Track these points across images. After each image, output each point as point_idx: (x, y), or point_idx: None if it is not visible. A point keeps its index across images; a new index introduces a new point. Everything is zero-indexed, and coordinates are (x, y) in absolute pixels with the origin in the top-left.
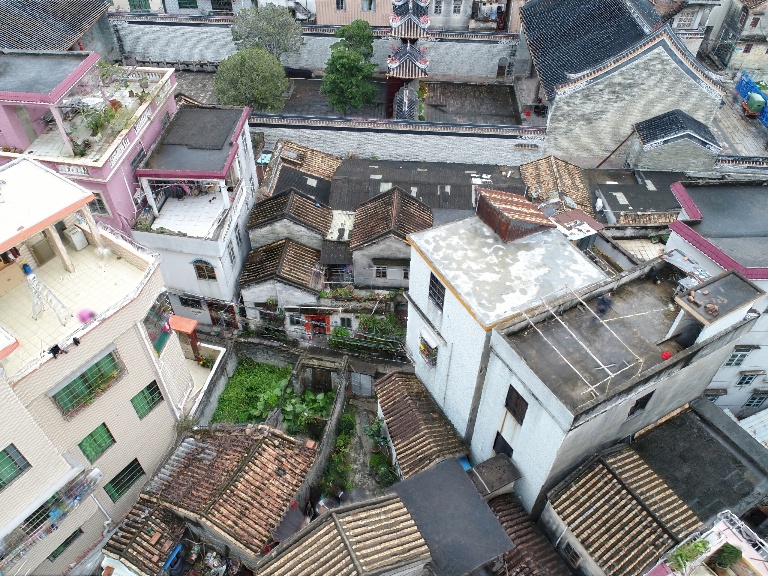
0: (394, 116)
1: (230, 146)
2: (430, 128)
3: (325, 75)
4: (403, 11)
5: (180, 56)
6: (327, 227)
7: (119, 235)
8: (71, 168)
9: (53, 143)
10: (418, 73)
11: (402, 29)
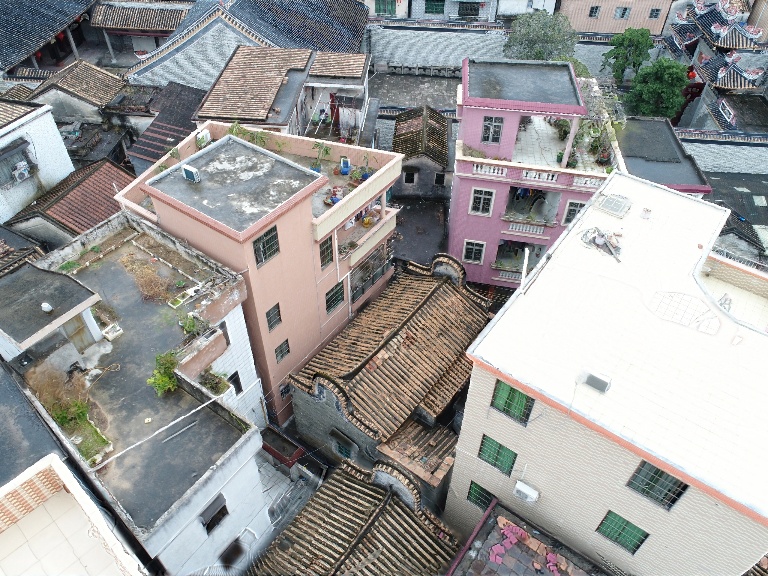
0: (693, 126)
1: (686, 159)
2: (759, 140)
3: (638, 84)
4: (714, 20)
5: (426, 61)
6: (760, 242)
7: (725, 252)
8: (592, 181)
9: (531, 154)
10: (744, 84)
11: (727, 39)
